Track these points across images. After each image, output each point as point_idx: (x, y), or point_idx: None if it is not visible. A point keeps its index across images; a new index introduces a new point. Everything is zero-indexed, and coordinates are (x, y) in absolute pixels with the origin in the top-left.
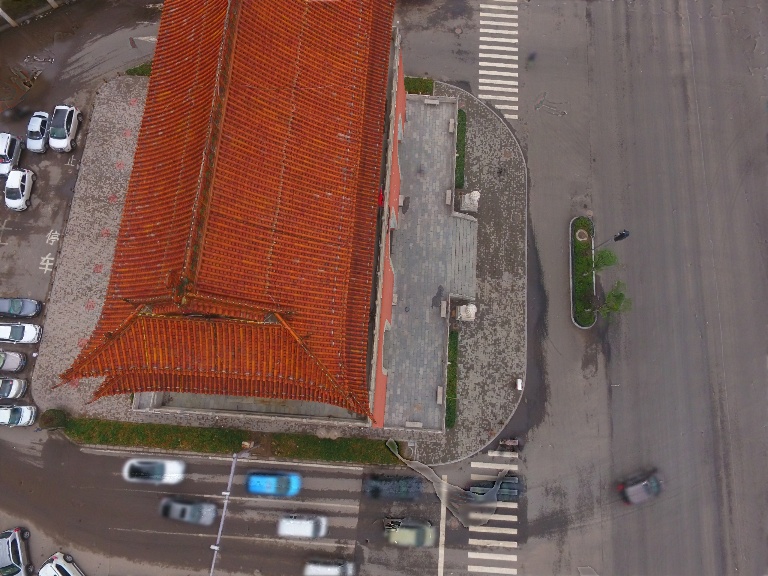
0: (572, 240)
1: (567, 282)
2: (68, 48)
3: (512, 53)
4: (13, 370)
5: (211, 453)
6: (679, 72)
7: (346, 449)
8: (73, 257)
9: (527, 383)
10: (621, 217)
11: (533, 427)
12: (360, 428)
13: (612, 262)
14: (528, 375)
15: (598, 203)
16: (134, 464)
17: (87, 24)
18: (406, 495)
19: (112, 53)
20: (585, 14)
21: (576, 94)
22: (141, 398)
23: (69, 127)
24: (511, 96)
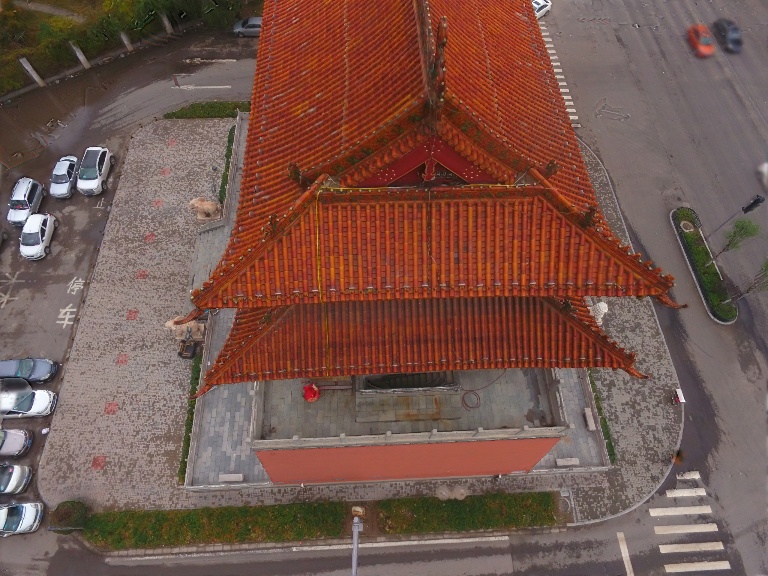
0: (679, 232)
1: (688, 276)
2: (100, 101)
3: (558, 73)
4: (14, 454)
5: (295, 542)
6: (723, 77)
7: (482, 510)
8: (101, 305)
9: (685, 396)
10: (721, 206)
11: (711, 451)
12: (495, 478)
13: (755, 231)
14: (682, 386)
15: (691, 195)
16: (185, 573)
17: (121, 80)
18: (576, 569)
19: (148, 102)
20: (616, 39)
21: (631, 102)
22: (195, 470)
23: (101, 168)
24: (568, 108)
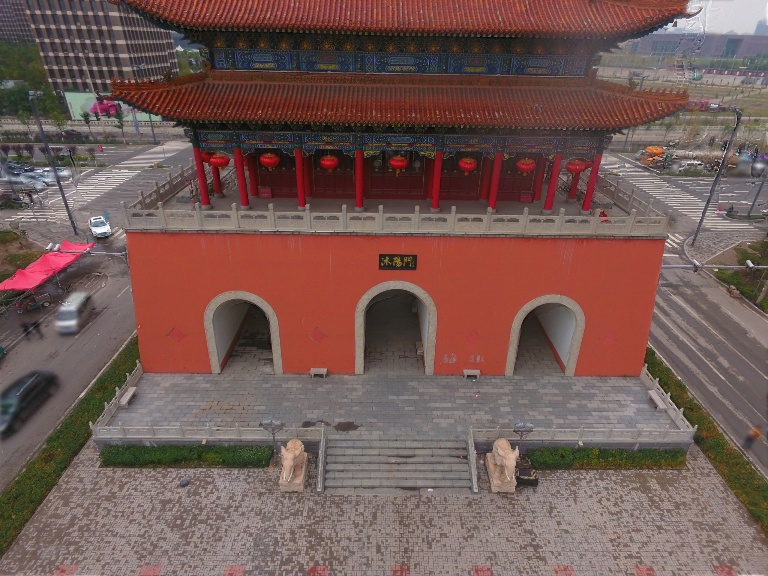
0: None
1: None
2: None
3: None
4: None
5: None
6: None
7: None
8: None
9: None
10: None
11: None
12: None
13: None
14: None
15: None
16: (763, 455)
17: None
18: None
19: None
20: None
21: None
22: None
23: None
24: None
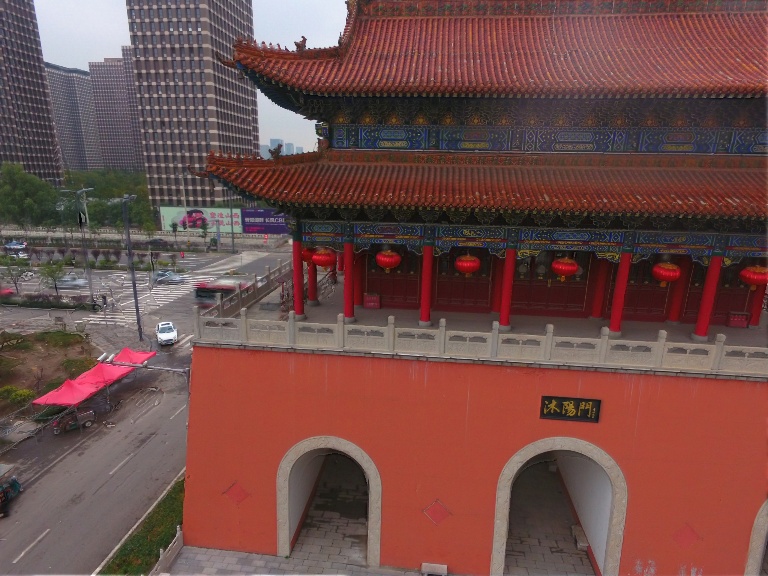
0: None
1: None
2: None
3: None
4: None
5: None
6: None
7: None
8: None
9: None
10: None
11: None
12: None
13: None
14: None
15: None
16: None
17: None
18: None
19: None
20: None
21: None
22: None
23: None
24: None
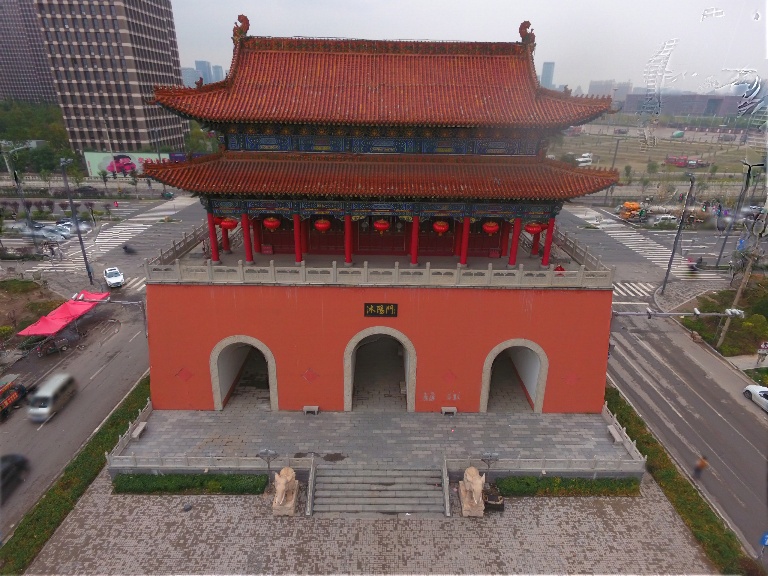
0: None
1: None
2: None
3: None
4: None
5: None
6: None
7: None
8: None
9: None
10: None
11: None
12: None
13: None
14: None
15: None
16: (711, 484)
17: None
18: None
19: None
20: None
21: None
22: None
23: None
24: None
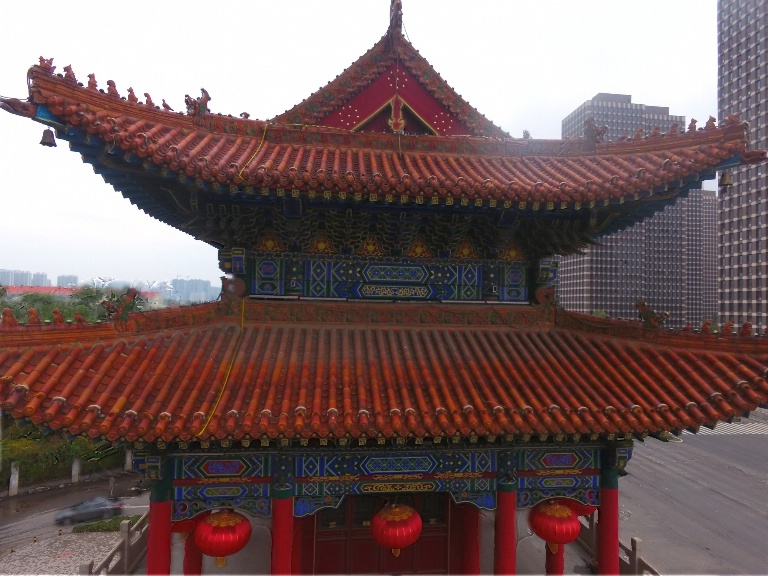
0: None
1: None
2: (1, 520)
3: None
4: None
5: None
6: (702, 487)
7: None
8: None
9: None
10: None
11: None
12: None
13: None
14: None
15: None
16: None
17: (44, 503)
18: None
19: (62, 520)
20: None
21: None
22: None
23: None
24: None
